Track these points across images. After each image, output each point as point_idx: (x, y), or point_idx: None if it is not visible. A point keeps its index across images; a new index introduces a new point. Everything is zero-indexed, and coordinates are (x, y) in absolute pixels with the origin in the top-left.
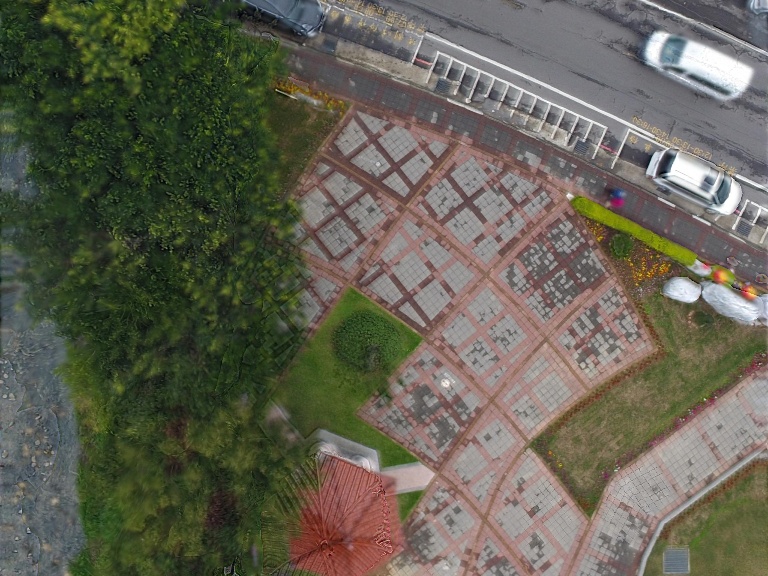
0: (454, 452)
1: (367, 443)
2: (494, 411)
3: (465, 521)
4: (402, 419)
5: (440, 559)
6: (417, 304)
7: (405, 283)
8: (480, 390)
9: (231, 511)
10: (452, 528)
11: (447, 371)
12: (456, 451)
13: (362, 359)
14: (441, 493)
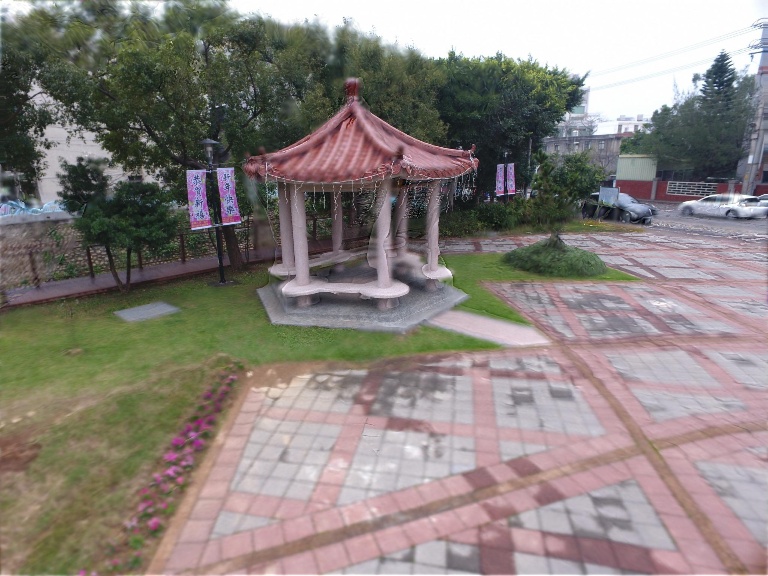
0: (622, 343)
1: (467, 290)
2: (767, 343)
3: (569, 414)
4: (544, 299)
5: (422, 427)
6: (651, 269)
7: (643, 262)
8: (737, 323)
9: (357, 30)
10: (517, 406)
11: (668, 299)
12: (628, 343)
13: (536, 254)
14: (542, 362)
